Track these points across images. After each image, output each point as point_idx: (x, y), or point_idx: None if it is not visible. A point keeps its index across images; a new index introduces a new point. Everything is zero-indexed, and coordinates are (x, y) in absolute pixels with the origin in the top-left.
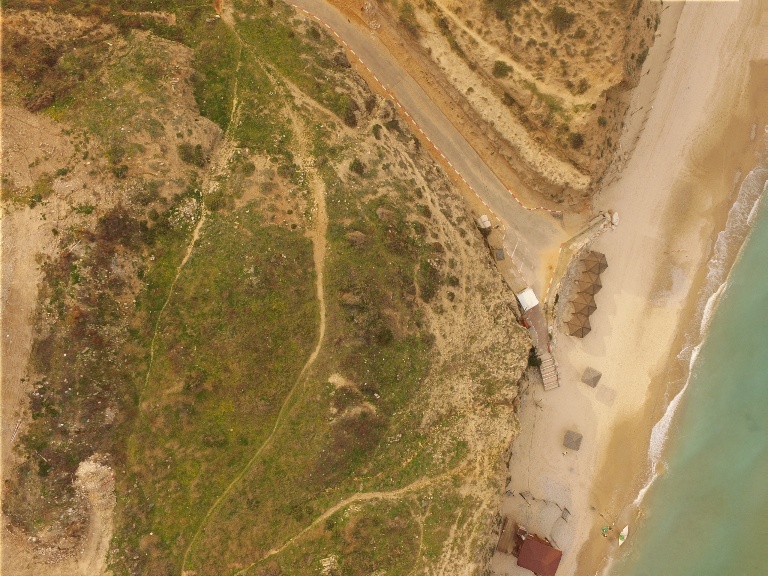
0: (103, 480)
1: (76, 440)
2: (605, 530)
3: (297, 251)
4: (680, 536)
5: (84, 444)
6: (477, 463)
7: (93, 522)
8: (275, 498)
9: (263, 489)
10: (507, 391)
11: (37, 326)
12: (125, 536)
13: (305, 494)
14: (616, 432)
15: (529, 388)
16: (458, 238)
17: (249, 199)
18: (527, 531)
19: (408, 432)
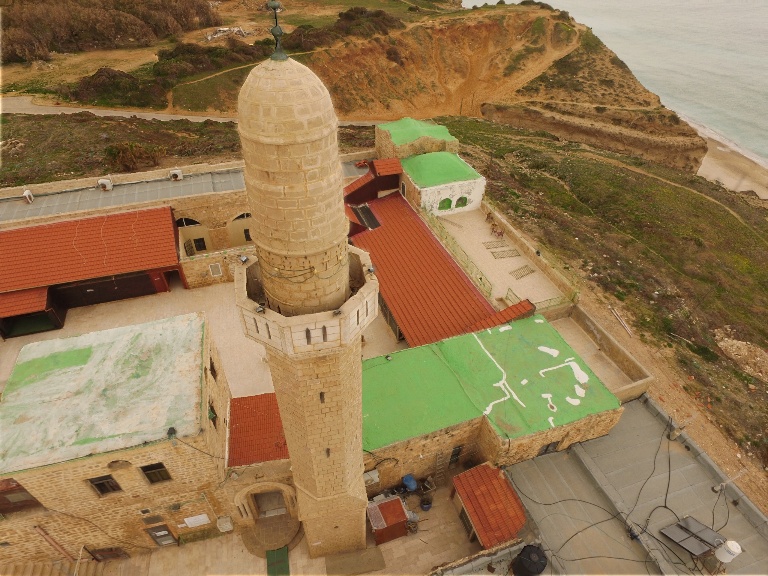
0: None
1: None
2: None
3: None
4: None
5: None
6: None
7: None
8: None
9: None
10: None
11: (524, 228)
12: None
13: None
14: None
15: None
16: None
17: (559, 158)
18: None
19: None
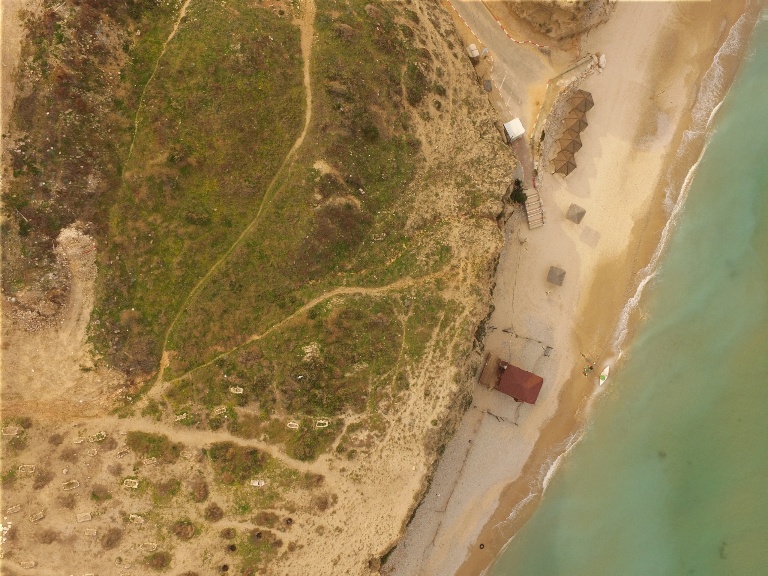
0: (85, 248)
1: (58, 201)
2: (586, 369)
3: (284, 36)
4: (659, 378)
5: (66, 209)
6: (460, 269)
7: (74, 292)
8: (258, 284)
9: (246, 273)
10: (491, 204)
11: (19, 83)
12: (106, 308)
13: (288, 283)
14: (599, 273)
15: (514, 226)
16: (446, 49)
17: None
18: (509, 359)
19: (392, 232)
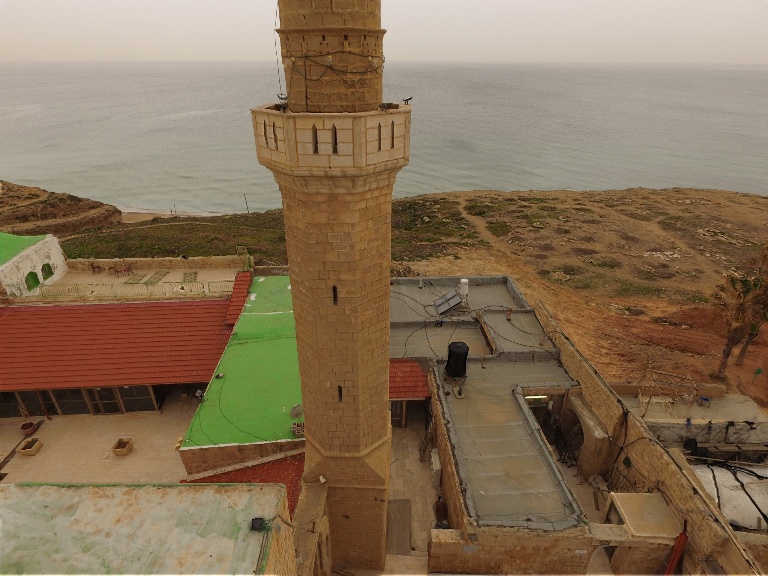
0: None
1: None
2: None
3: None
4: None
5: None
6: None
7: None
8: None
9: None
10: None
11: None
12: None
13: None
14: None
15: None
16: None
17: None
18: None
19: None
